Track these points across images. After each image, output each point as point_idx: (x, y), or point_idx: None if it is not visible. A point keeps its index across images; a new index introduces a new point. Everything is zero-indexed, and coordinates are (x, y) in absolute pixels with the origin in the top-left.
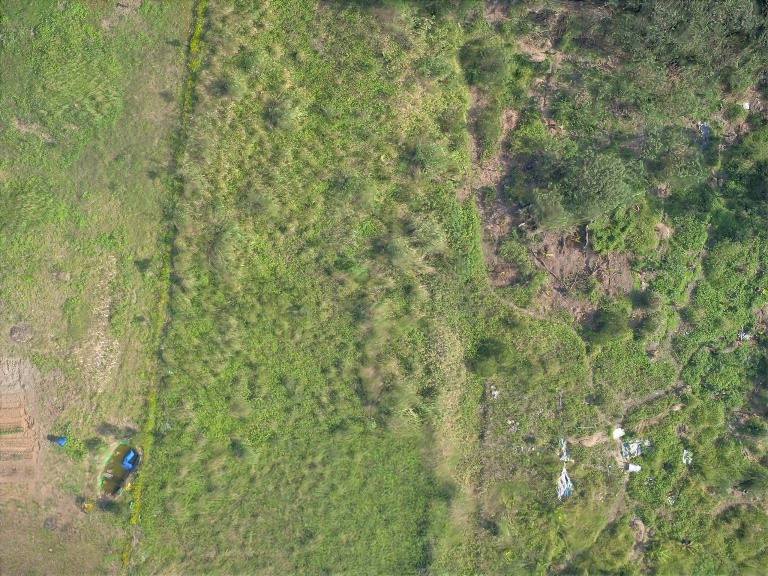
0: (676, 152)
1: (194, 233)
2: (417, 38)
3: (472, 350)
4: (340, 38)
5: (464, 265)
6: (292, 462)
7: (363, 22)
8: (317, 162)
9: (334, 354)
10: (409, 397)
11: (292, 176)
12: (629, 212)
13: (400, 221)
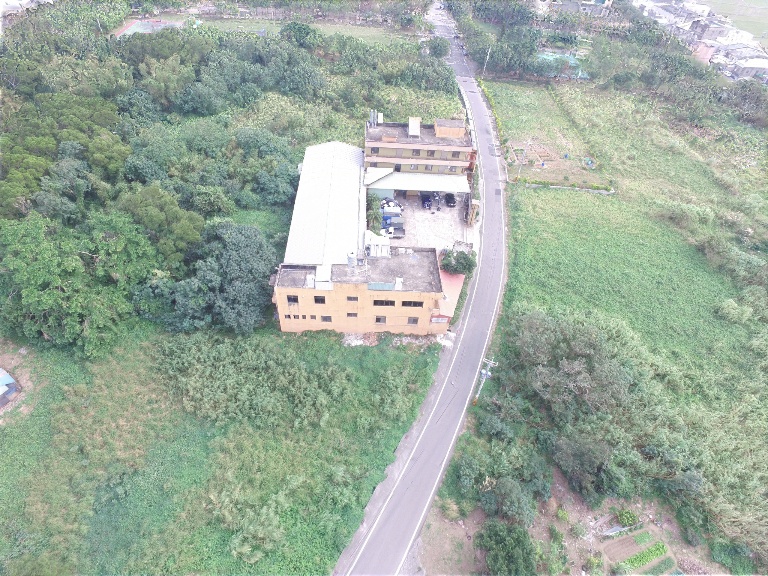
0: None
1: None
2: None
3: None
4: None
5: None
6: None
7: None
8: None
9: None
10: None
11: None
12: None
13: None
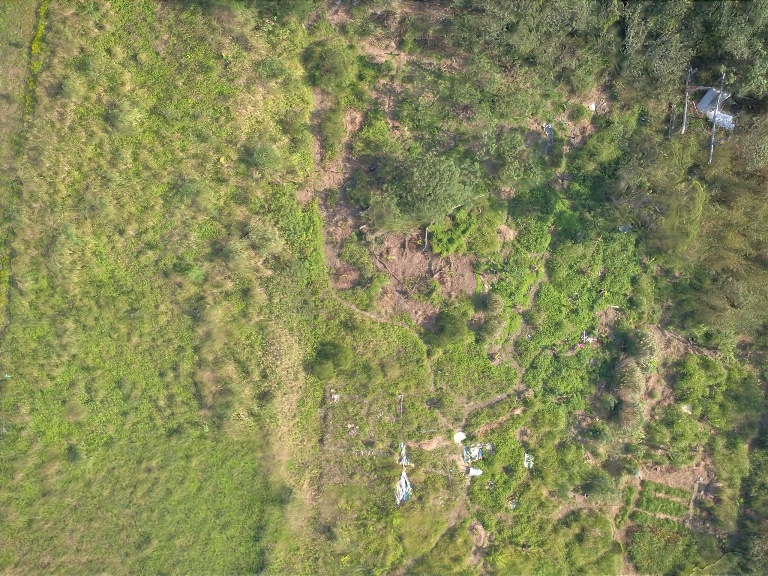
0: (510, 154)
1: (32, 236)
2: (259, 39)
3: (311, 353)
4: (182, 39)
5: (298, 268)
6: (127, 466)
7: (205, 23)
8: (157, 164)
9: (172, 357)
10: (239, 401)
11: (131, 178)
12: (471, 214)
13: (239, 223)
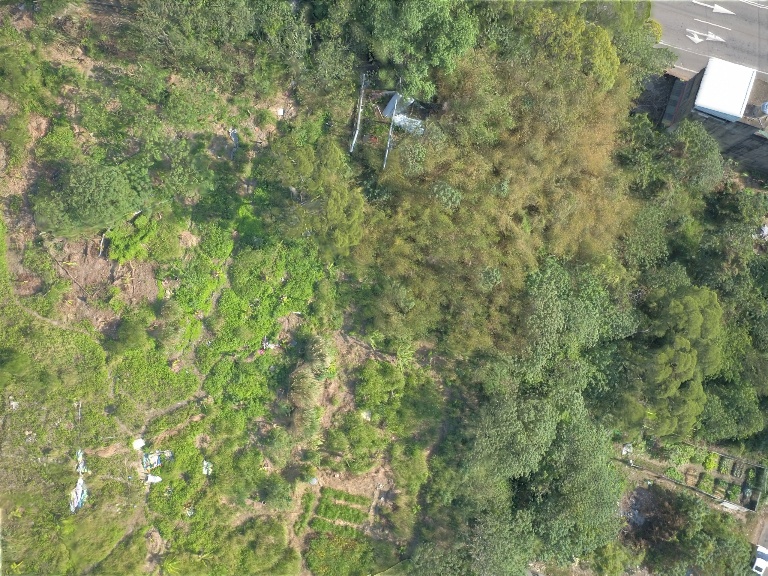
0: (175, 159)
1: None
2: None
3: None
4: None
5: None
6: None
7: None
8: None
9: None
10: None
11: None
12: (151, 220)
13: None
